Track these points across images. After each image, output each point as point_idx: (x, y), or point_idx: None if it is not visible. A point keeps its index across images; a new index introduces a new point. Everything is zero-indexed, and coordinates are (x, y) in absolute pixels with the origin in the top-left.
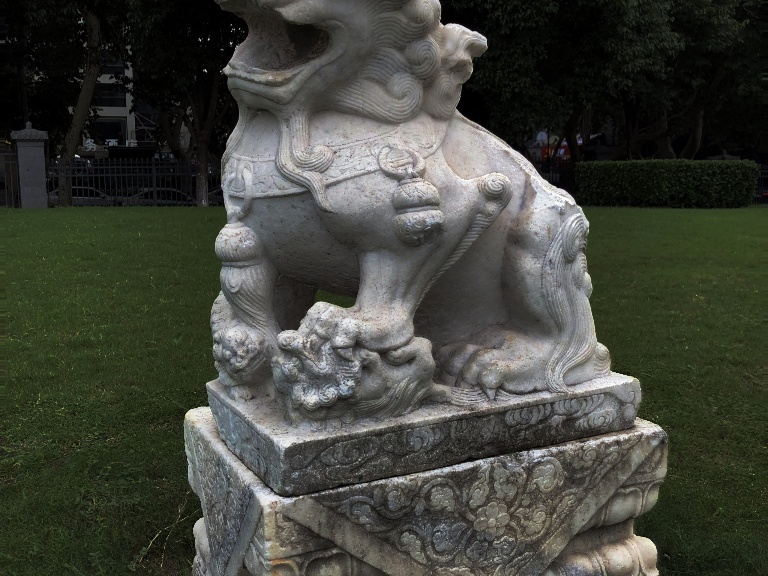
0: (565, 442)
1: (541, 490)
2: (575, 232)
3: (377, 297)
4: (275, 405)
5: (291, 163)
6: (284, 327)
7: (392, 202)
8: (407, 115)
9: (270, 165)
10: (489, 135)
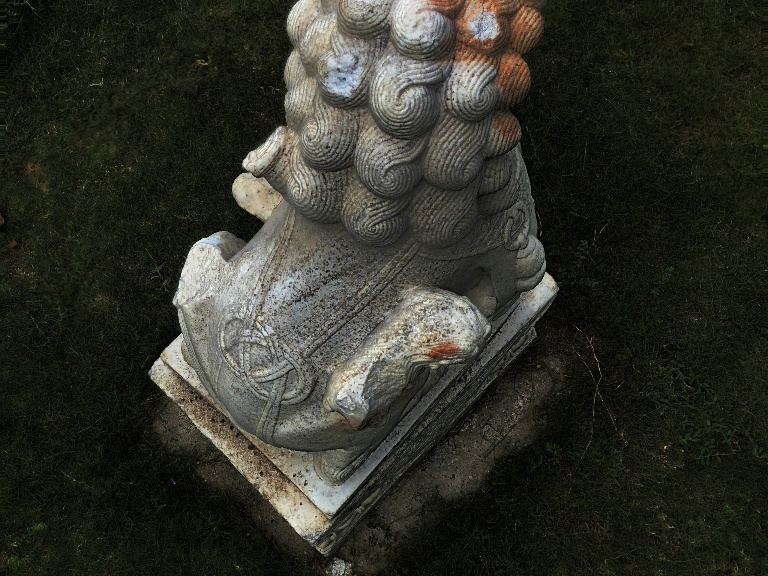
0: None
1: None
2: None
3: None
4: None
5: None
6: None
7: None
8: None
9: None
10: (264, 259)
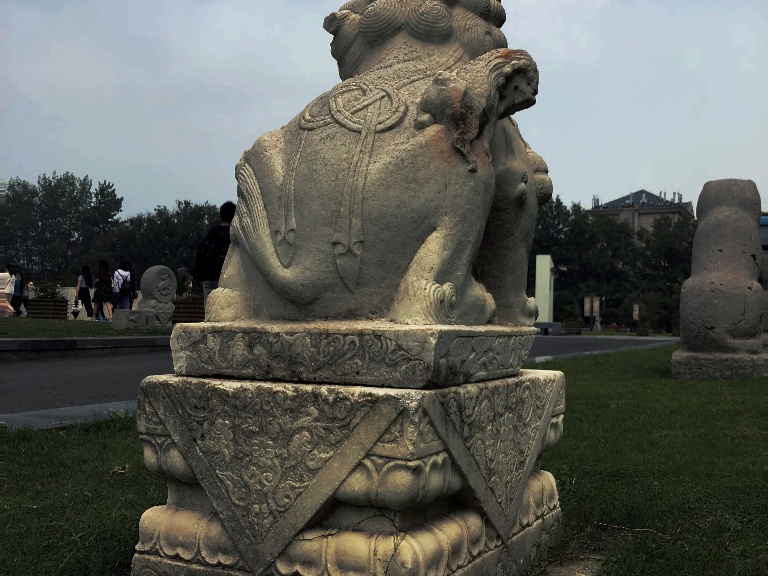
0: None
1: None
2: None
3: None
4: None
5: None
6: None
7: None
8: None
9: None
10: None
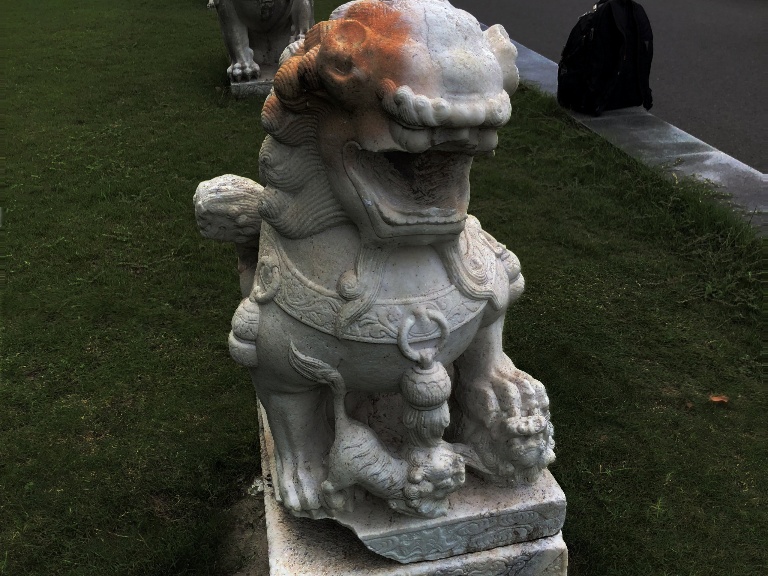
0: None
1: None
2: None
3: (501, 355)
4: (468, 491)
5: (475, 284)
6: (333, 440)
7: (508, 277)
8: None
9: (456, 295)
10: None
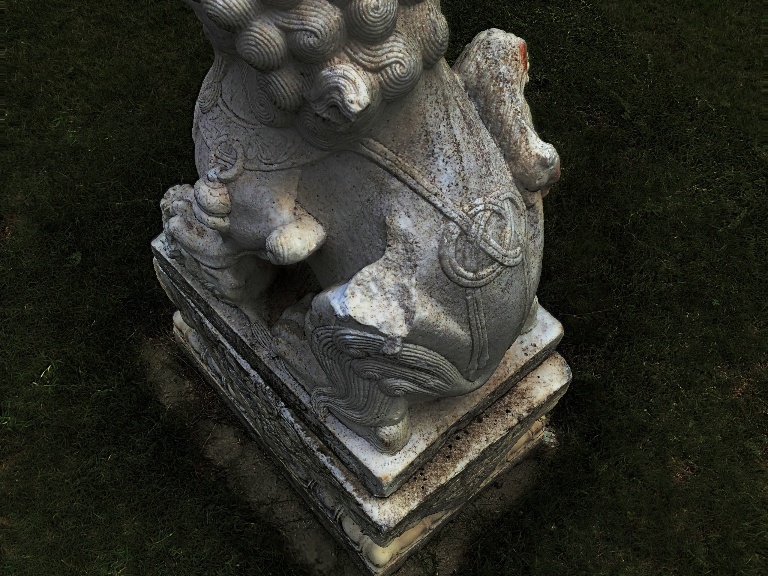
0: (316, 436)
1: (287, 432)
2: (349, 343)
3: None
4: None
5: None
6: None
7: None
8: (266, 122)
9: None
10: (405, 192)
